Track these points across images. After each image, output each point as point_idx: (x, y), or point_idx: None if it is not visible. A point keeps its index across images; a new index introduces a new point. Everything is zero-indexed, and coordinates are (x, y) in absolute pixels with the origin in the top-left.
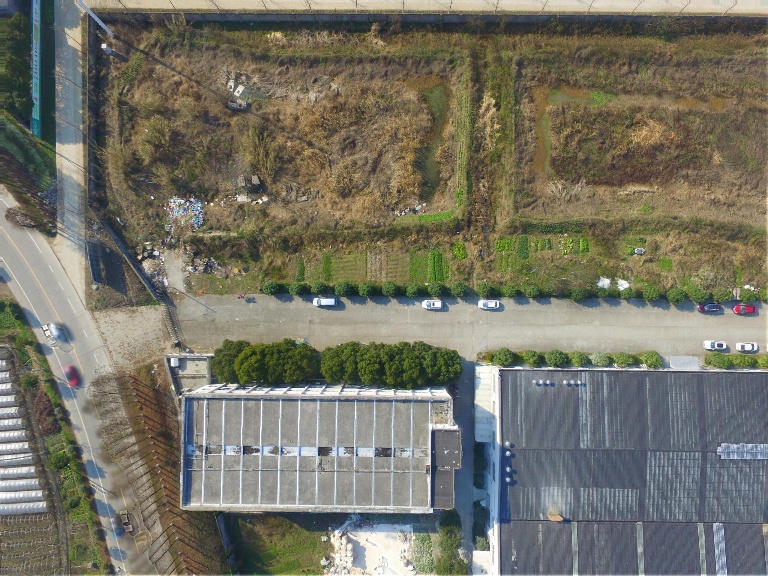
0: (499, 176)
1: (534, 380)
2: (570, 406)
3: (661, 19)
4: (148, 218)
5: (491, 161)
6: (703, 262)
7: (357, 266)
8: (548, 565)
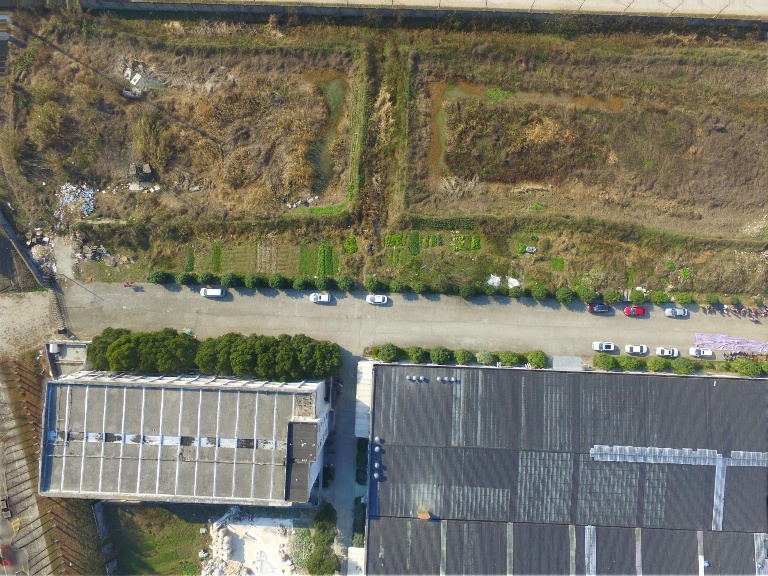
0: (392, 171)
1: (408, 376)
2: (443, 403)
3: (558, 17)
4: (38, 204)
5: (385, 155)
6: (595, 262)
7: (247, 257)
8: (415, 563)
